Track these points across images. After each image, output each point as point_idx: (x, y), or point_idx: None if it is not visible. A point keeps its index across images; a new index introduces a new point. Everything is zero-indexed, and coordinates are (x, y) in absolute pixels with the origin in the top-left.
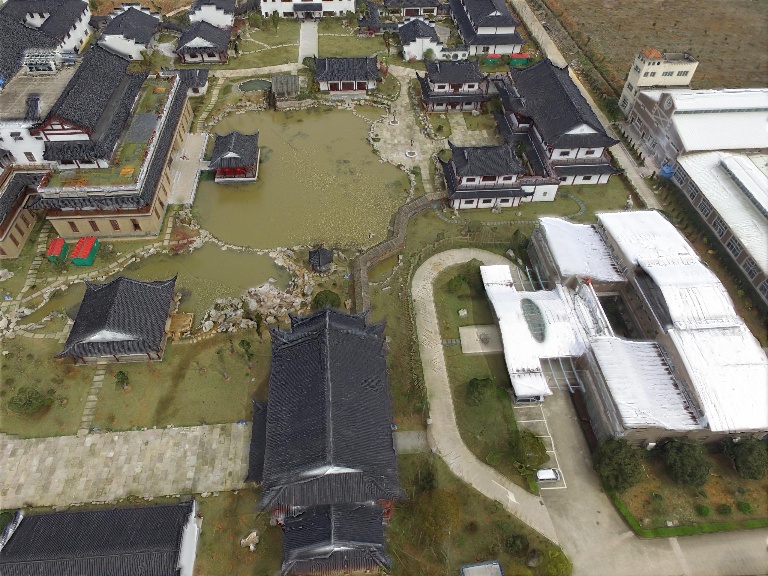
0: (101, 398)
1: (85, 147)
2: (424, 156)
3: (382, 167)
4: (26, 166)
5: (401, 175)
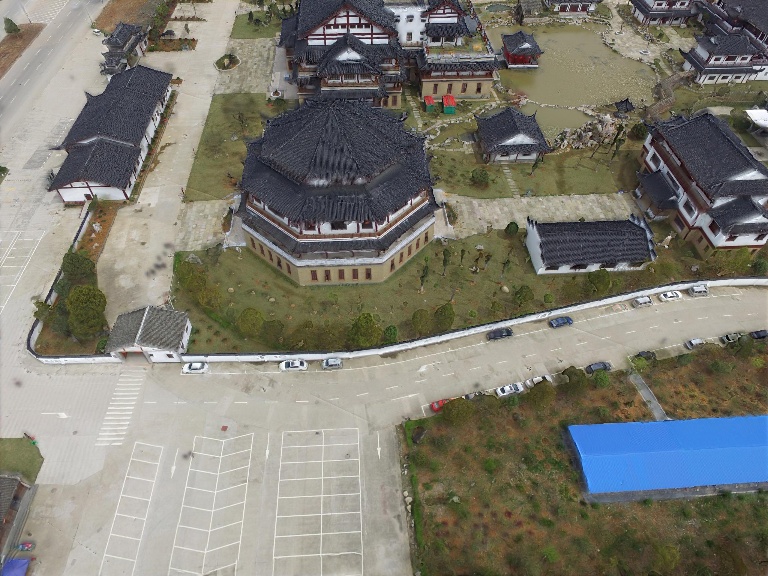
0: (517, 180)
1: (454, 28)
2: (655, 54)
3: (626, 61)
4: (406, 43)
5: (643, 66)
